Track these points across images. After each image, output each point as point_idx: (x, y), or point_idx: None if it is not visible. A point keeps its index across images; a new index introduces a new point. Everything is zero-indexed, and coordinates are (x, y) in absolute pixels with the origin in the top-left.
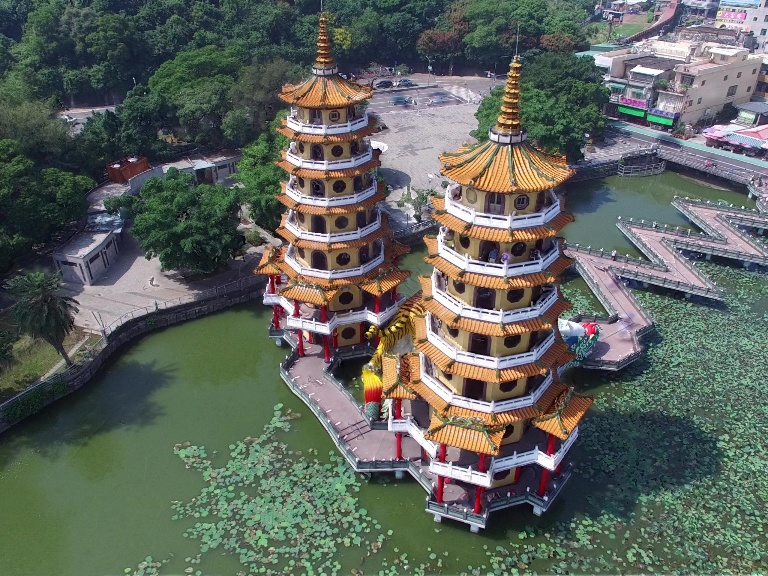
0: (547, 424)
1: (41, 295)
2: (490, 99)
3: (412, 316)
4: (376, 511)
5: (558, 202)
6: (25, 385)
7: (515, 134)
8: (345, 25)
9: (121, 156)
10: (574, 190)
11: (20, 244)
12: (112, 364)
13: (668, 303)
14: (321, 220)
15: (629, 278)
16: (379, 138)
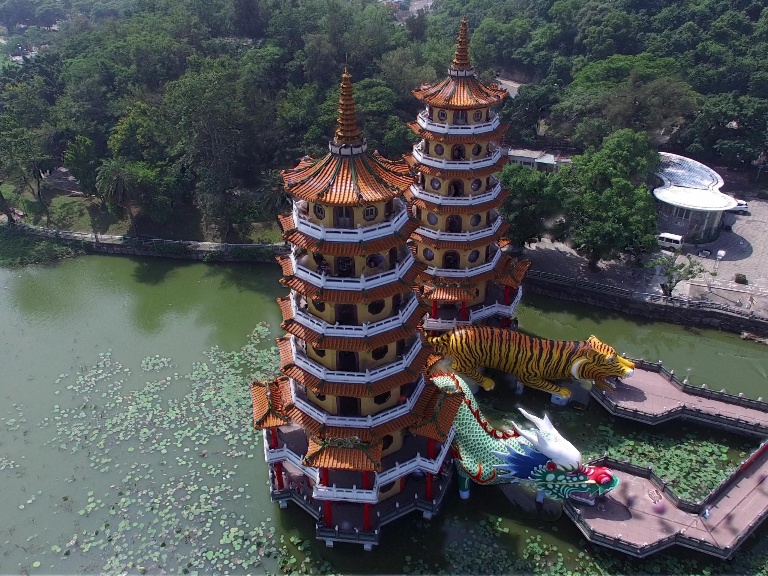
0: (313, 446)
1: None
2: None
3: (452, 338)
4: None
5: (358, 230)
6: (260, 243)
7: None
8: None
9: None
10: None
11: None
12: None
13: None
14: None
15: None
16: None
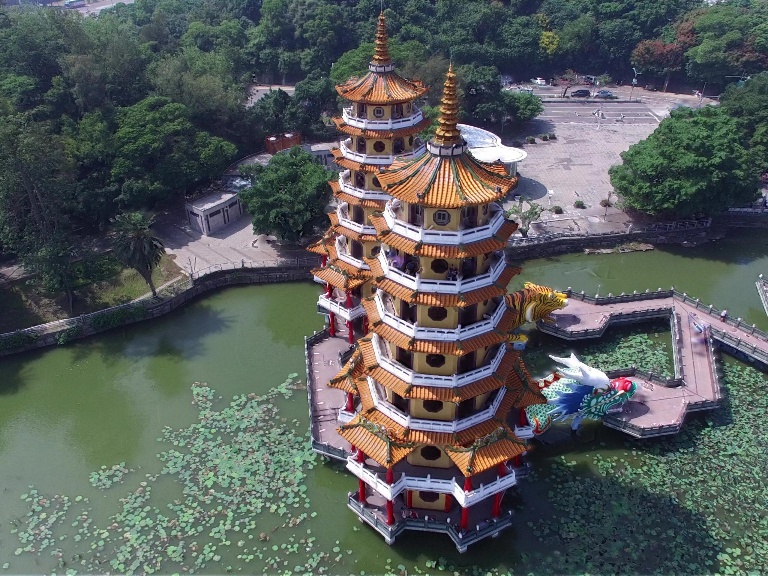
0: (459, 456)
1: None
2: (669, 120)
3: None
4: (315, 492)
5: (489, 225)
6: (118, 303)
7: (446, 146)
8: (557, 29)
9: (282, 131)
10: (741, 236)
11: (157, 190)
12: (191, 304)
13: (767, 385)
14: (361, 211)
15: (729, 345)
16: (541, 147)
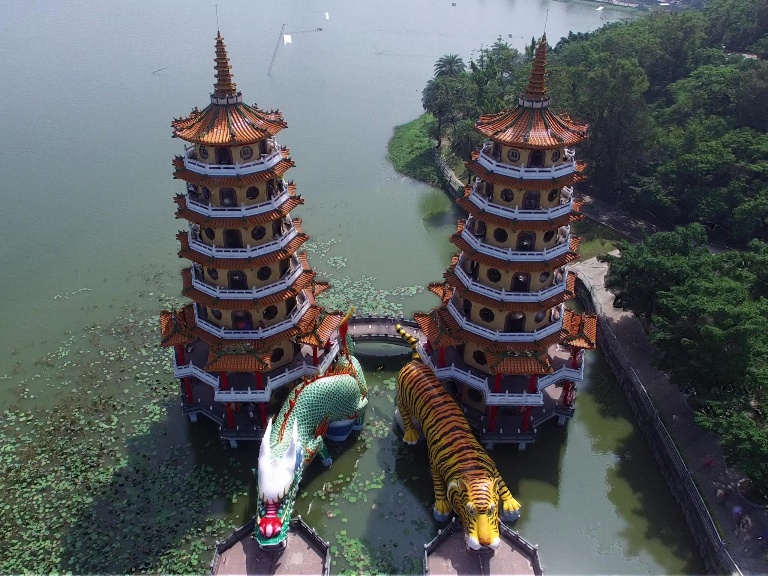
0: None
1: None
2: None
3: None
4: None
5: None
6: None
7: None
8: None
9: None
10: None
11: None
12: None
13: None
14: None
15: None
16: None
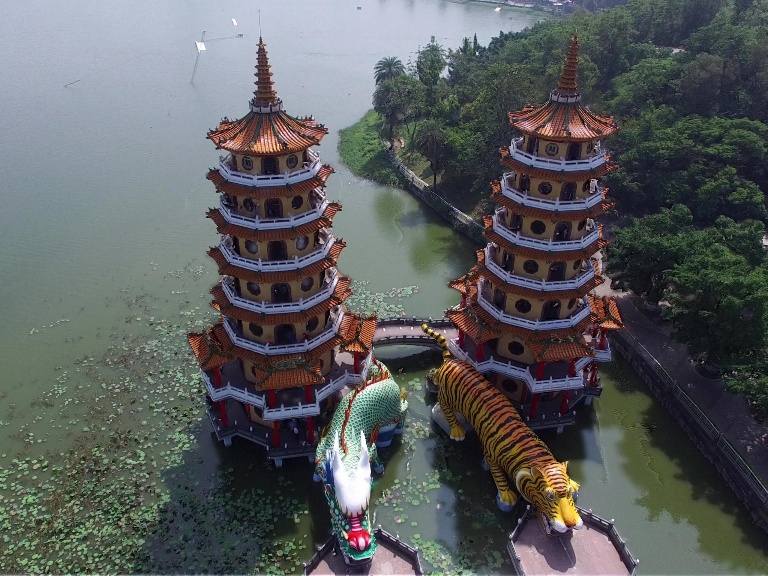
0: None
1: None
2: None
3: None
4: None
5: (228, 170)
6: None
7: None
8: None
9: None
10: None
11: None
12: None
13: None
14: None
15: None
16: None
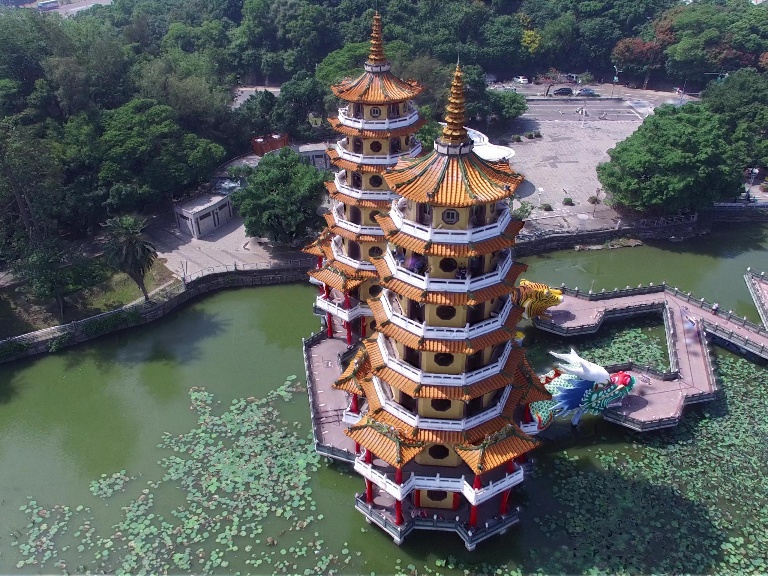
0: (468, 454)
1: (123, 236)
2: (653, 117)
3: None
4: (320, 494)
5: (498, 223)
6: (110, 309)
7: (454, 145)
8: (538, 28)
9: (269, 132)
10: (726, 231)
11: (146, 194)
12: (184, 308)
13: (760, 376)
14: (358, 211)
15: (721, 337)
16: (526, 145)
